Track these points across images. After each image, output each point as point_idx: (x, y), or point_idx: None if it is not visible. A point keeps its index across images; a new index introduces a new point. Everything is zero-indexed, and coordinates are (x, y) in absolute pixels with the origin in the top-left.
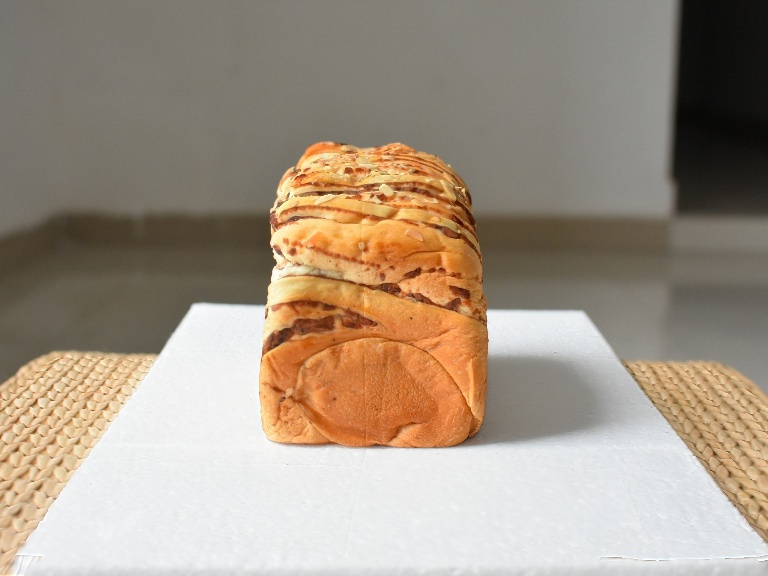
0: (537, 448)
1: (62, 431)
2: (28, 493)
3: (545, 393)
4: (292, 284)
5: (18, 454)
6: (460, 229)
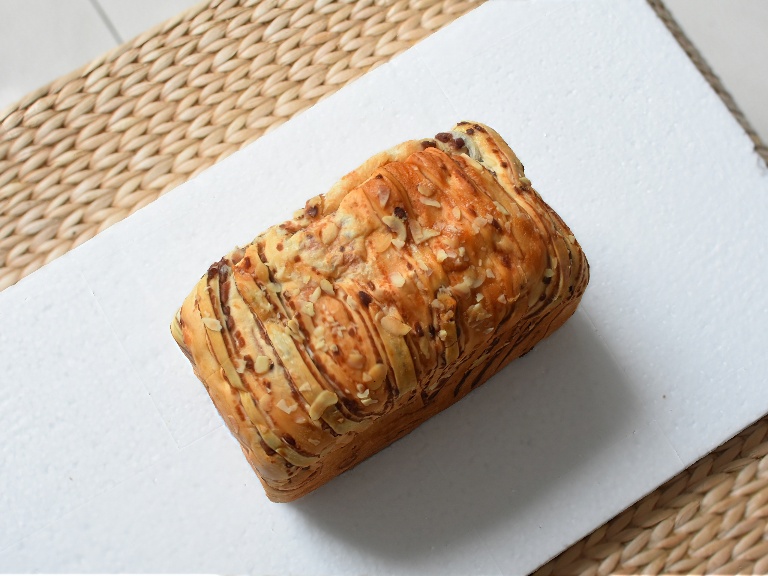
0: (304, 554)
1: (216, 106)
2: (67, 211)
3: (495, 467)
4: (179, 333)
5: (140, 129)
6: (285, 447)
